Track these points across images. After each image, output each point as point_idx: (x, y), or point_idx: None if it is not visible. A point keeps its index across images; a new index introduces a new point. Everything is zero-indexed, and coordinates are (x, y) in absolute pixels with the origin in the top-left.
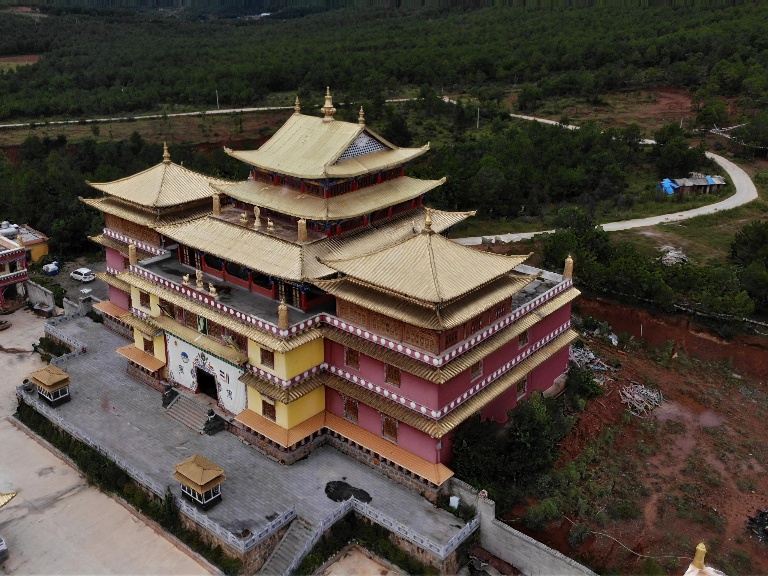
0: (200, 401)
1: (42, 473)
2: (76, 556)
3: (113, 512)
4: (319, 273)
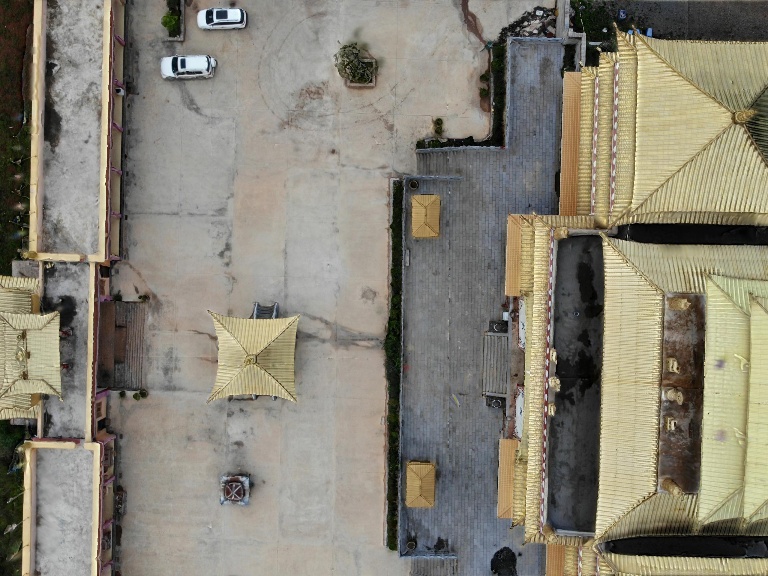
0: (512, 363)
1: (365, 295)
2: (327, 421)
3: (376, 397)
4: (631, 533)
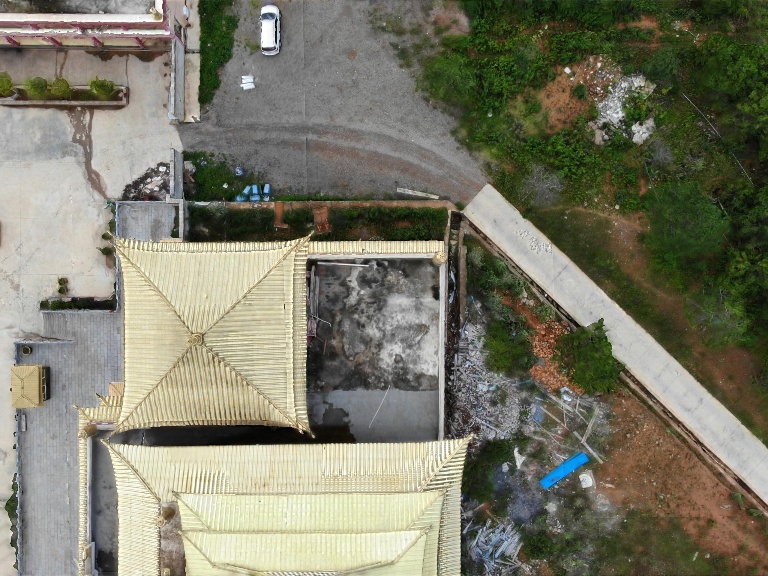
0: None
1: None
2: None
3: (10, 558)
4: None
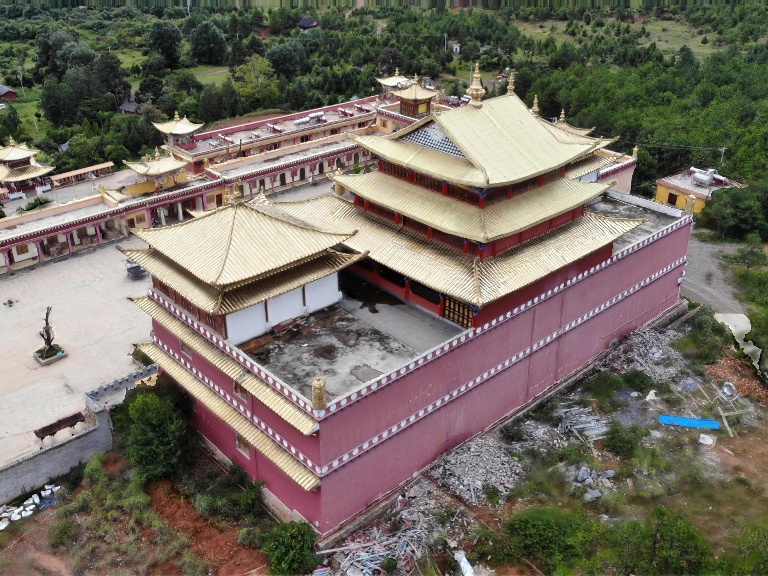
0: None
1: None
2: None
3: None
4: (293, 214)
